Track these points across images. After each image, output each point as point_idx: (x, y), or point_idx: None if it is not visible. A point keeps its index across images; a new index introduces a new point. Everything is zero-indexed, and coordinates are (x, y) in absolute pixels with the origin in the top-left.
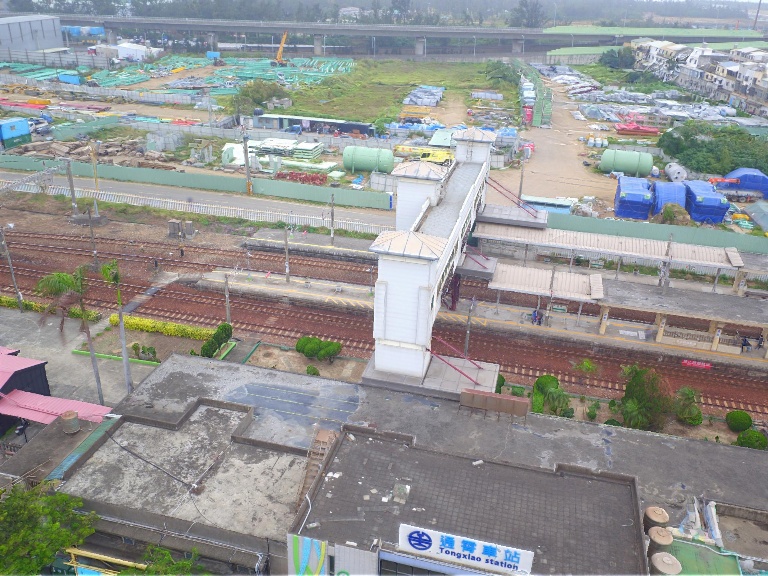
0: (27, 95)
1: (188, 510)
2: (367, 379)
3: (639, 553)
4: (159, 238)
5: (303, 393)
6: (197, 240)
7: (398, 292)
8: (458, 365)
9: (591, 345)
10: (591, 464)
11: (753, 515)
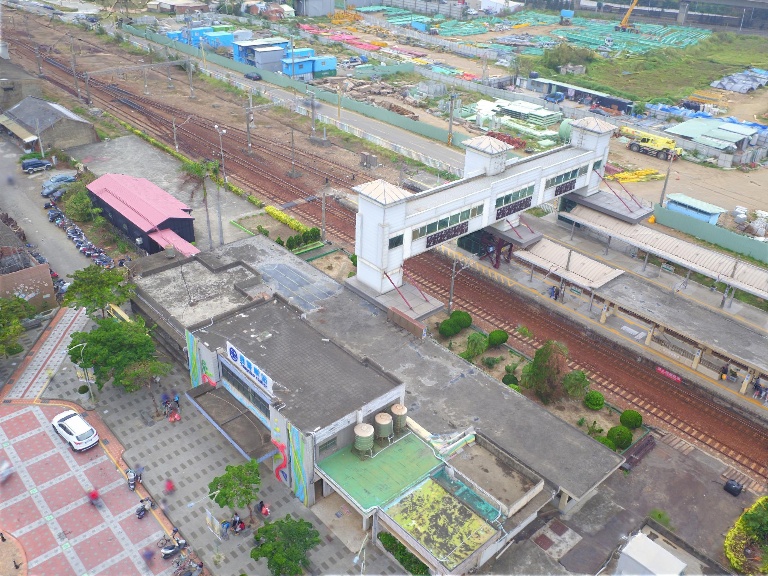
0: (377, 36)
1: (179, 311)
2: (346, 283)
3: None
4: (353, 164)
5: (305, 279)
6: (376, 171)
7: (368, 224)
8: (415, 295)
9: (585, 328)
10: (430, 382)
11: (497, 452)
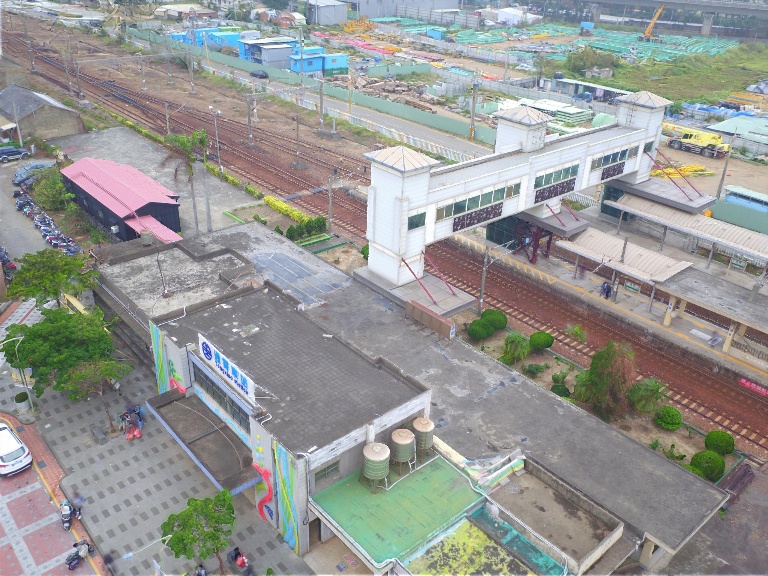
0: (391, 43)
1: (149, 303)
2: (355, 273)
3: None
4: None
5: (306, 270)
6: None
7: (383, 199)
8: (440, 287)
9: (645, 332)
10: (462, 392)
11: (555, 484)
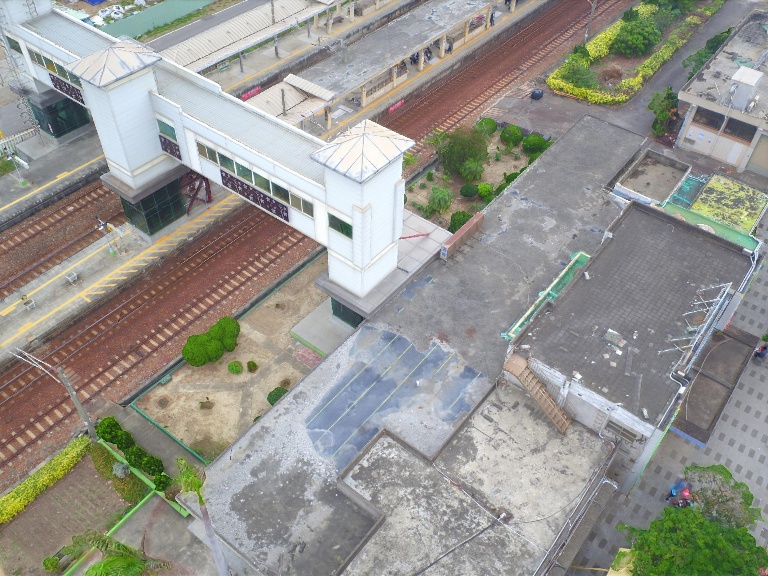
0: None
1: (534, 530)
2: None
3: (703, 237)
4: None
5: (355, 376)
6: None
7: (378, 206)
8: None
9: None
10: (549, 221)
11: None
